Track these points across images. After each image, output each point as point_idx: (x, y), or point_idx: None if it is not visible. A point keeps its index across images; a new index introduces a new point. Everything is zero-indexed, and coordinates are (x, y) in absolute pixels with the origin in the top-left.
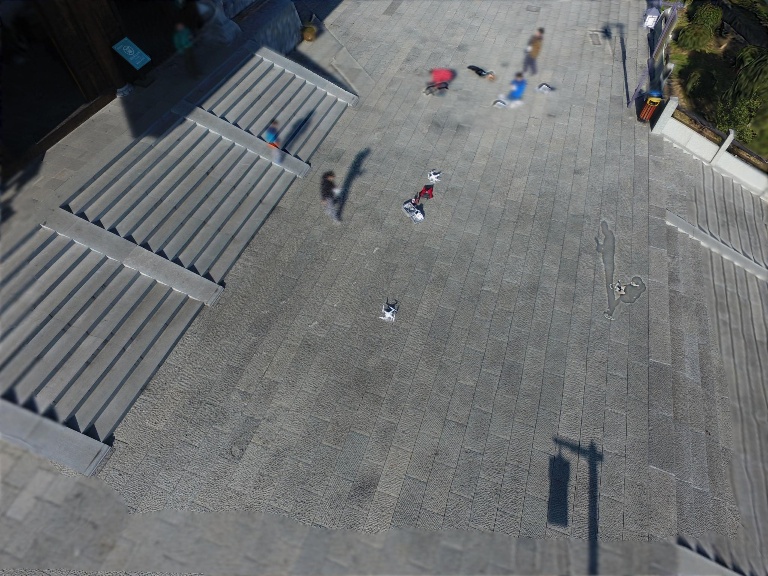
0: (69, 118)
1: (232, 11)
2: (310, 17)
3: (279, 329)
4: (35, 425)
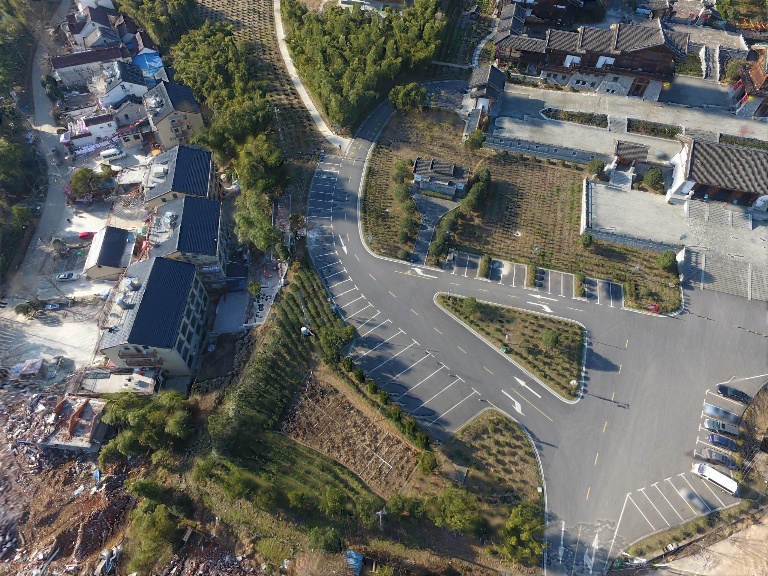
0: (721, 200)
1: (757, 209)
2: None
3: None
4: (688, 212)
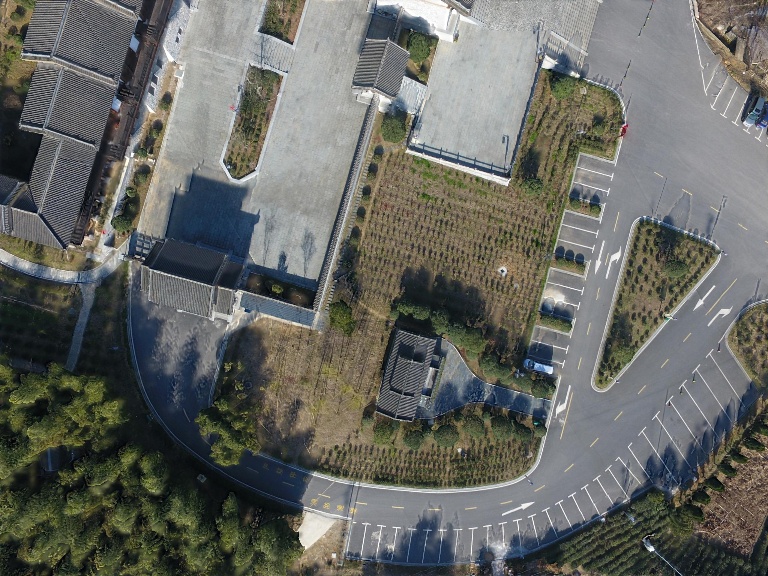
0: None
1: None
2: None
3: (501, 5)
4: None
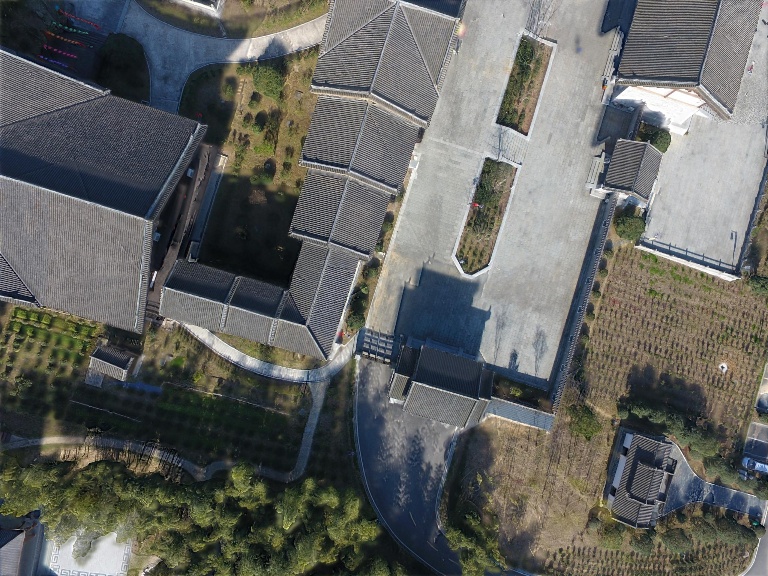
0: None
1: None
2: None
3: None
4: None
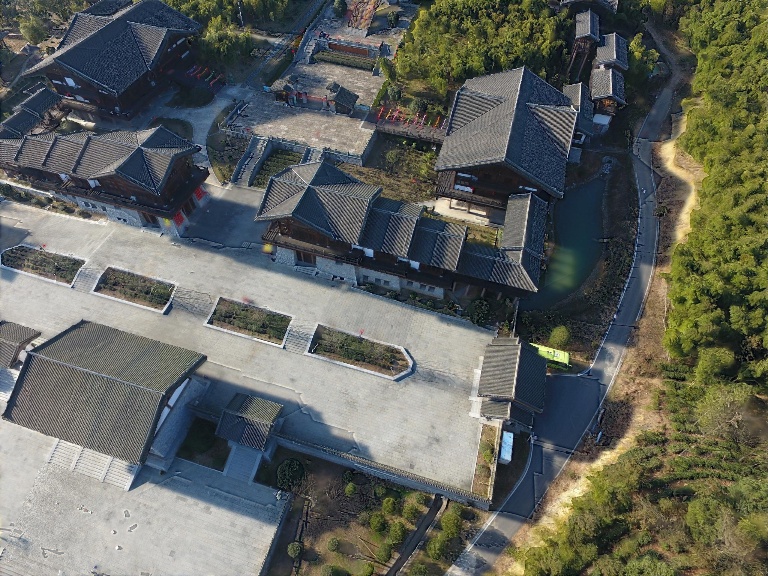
0: None
1: None
2: (179, 471)
3: None
4: None
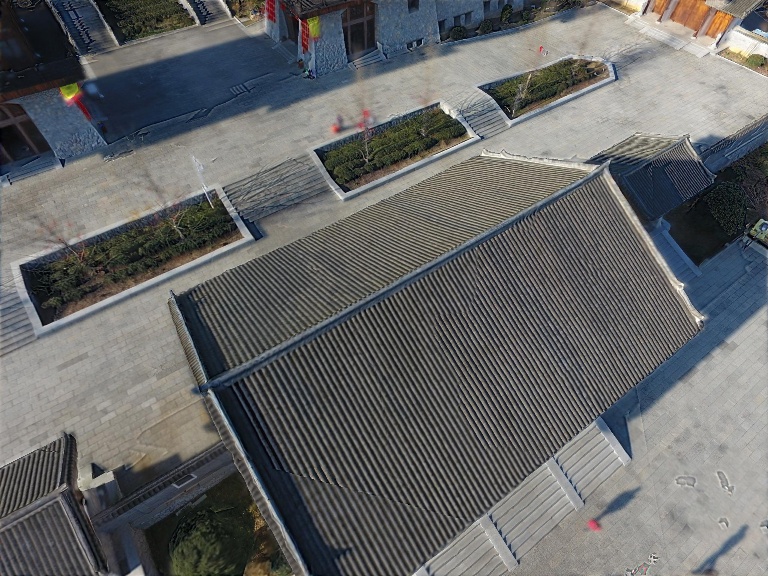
0: None
1: None
2: None
3: None
4: None
